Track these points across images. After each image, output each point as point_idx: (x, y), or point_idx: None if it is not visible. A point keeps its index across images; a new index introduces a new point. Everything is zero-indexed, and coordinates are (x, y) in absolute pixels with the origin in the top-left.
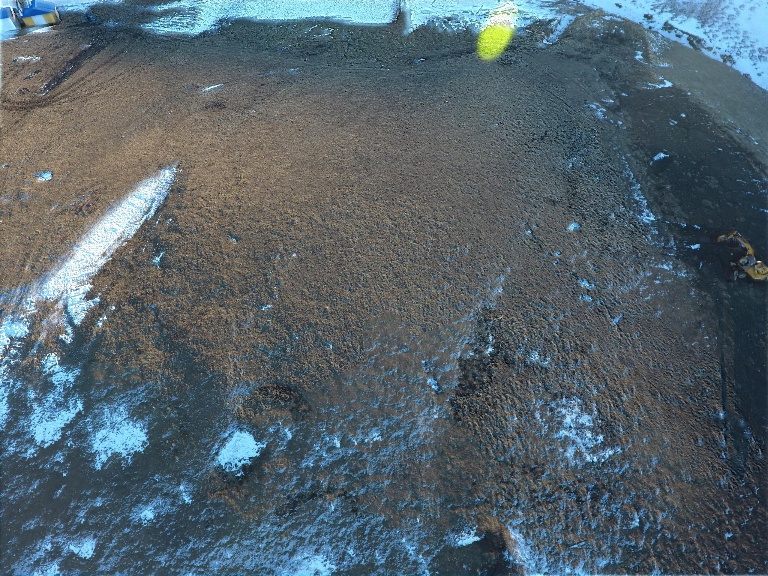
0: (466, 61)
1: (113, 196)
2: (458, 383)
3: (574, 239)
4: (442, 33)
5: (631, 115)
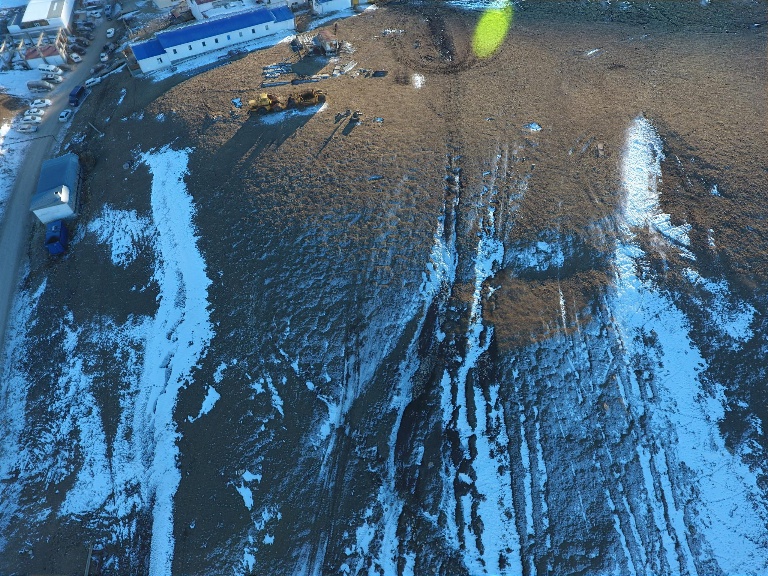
0: None
1: (616, 142)
2: None
3: None
4: (743, 3)
5: None
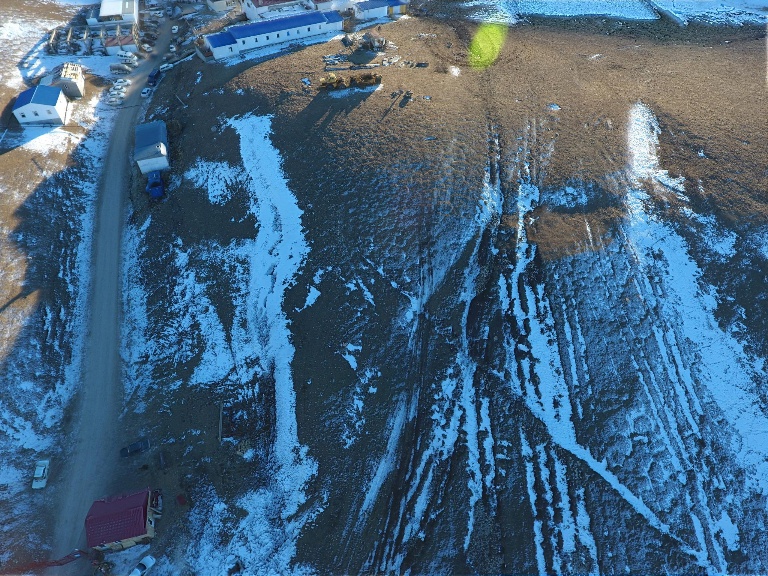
0: None
1: (621, 119)
2: None
3: None
4: (715, 26)
5: None
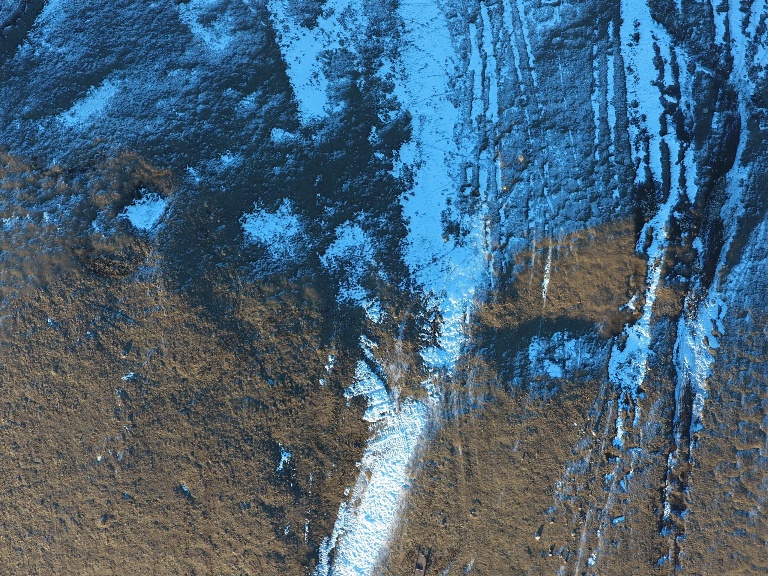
0: None
1: None
2: None
3: None
4: None
5: None
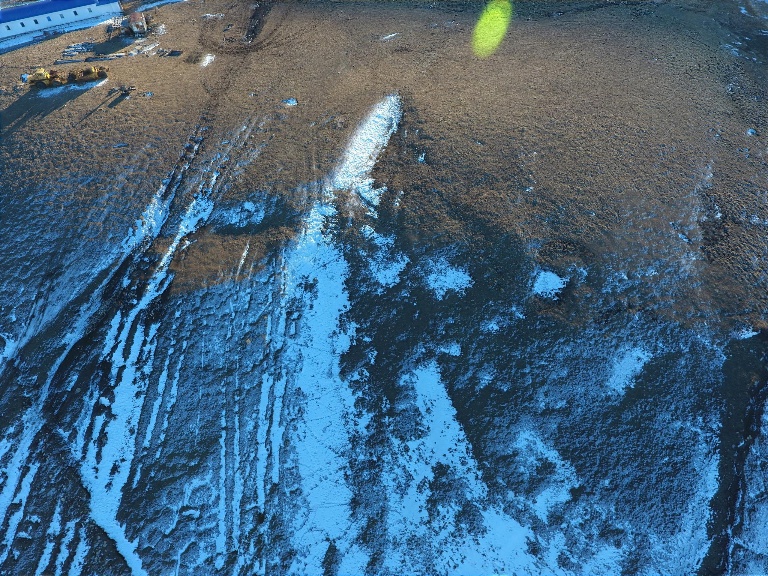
0: (603, 13)
1: (358, 115)
2: (703, 237)
3: (755, 140)
4: None
5: (762, 53)
